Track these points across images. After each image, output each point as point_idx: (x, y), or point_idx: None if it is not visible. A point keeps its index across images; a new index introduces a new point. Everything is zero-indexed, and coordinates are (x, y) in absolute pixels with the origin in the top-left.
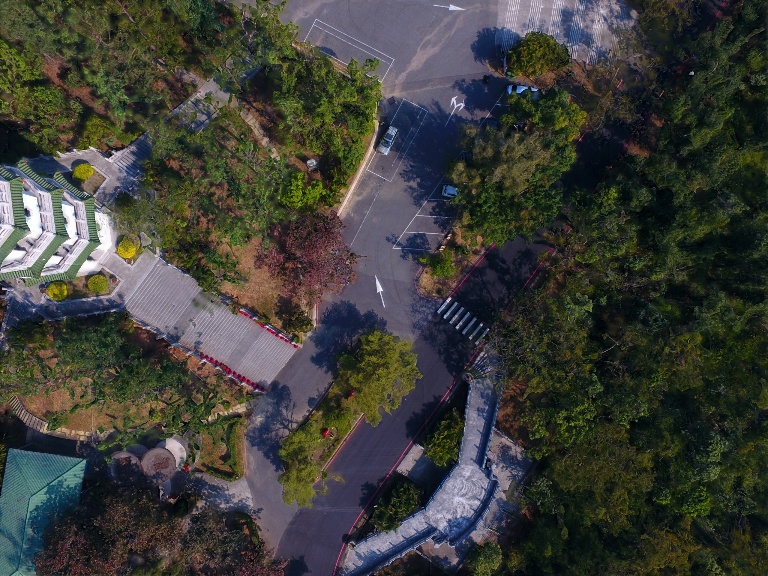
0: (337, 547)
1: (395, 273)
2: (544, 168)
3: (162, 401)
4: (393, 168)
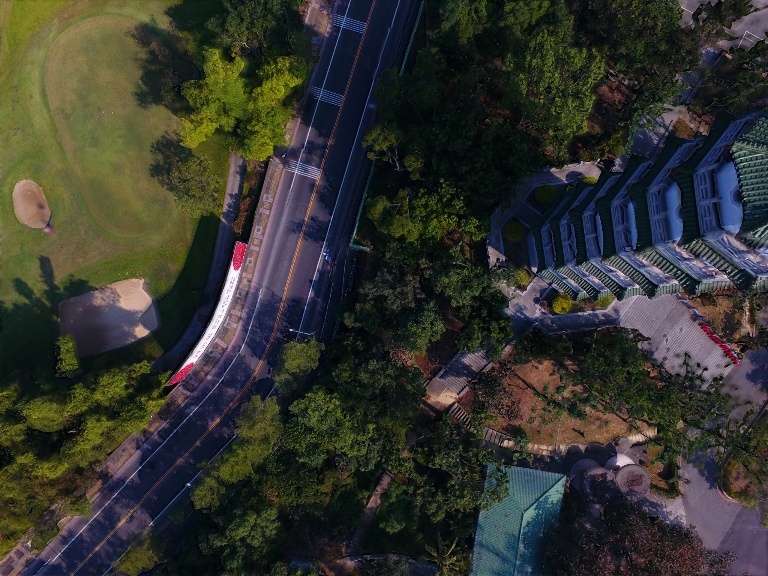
0: (767, 567)
1: None
2: None
3: (619, 416)
4: None
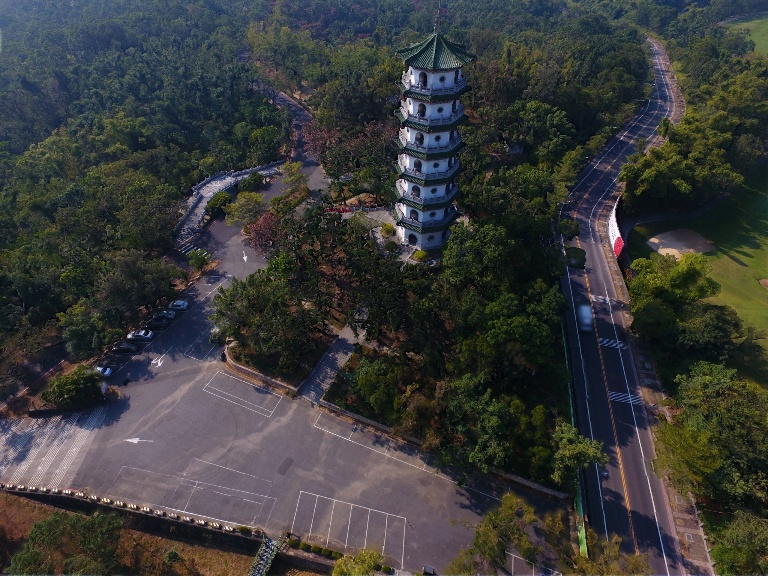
0: None
1: (233, 265)
2: None
3: None
4: None
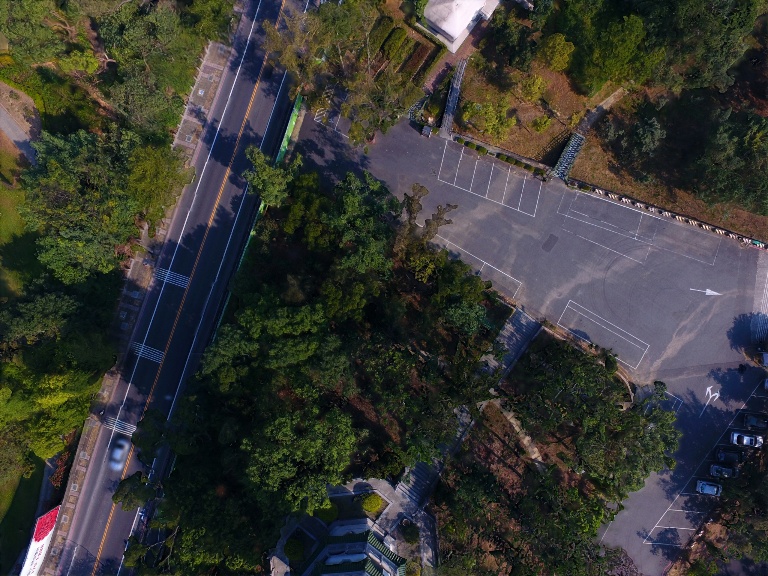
0: None
1: (644, 568)
2: None
3: None
4: None
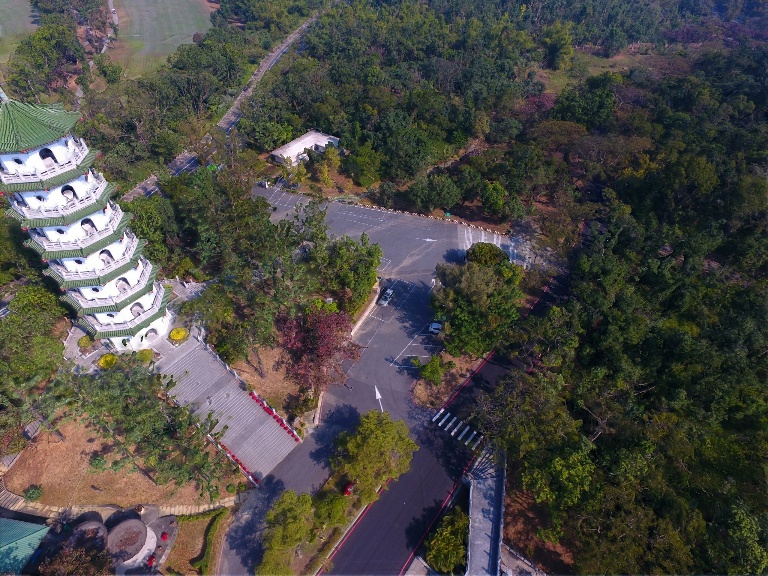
0: None
1: (392, 384)
2: (500, 291)
3: None
4: (390, 315)
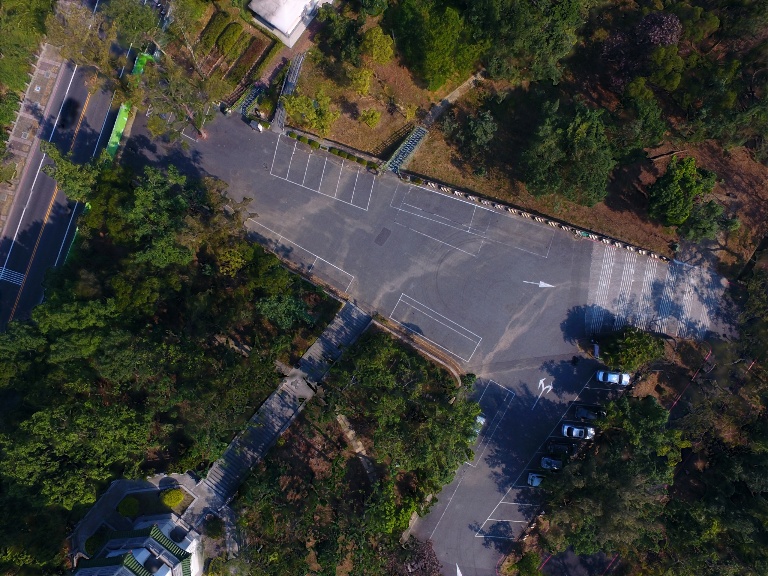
0: None
1: (477, 561)
2: (647, 506)
3: None
4: (478, 453)
